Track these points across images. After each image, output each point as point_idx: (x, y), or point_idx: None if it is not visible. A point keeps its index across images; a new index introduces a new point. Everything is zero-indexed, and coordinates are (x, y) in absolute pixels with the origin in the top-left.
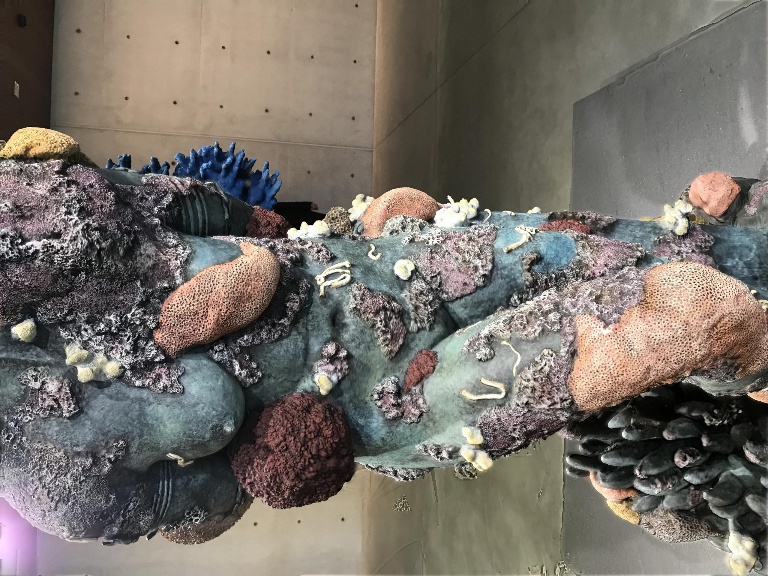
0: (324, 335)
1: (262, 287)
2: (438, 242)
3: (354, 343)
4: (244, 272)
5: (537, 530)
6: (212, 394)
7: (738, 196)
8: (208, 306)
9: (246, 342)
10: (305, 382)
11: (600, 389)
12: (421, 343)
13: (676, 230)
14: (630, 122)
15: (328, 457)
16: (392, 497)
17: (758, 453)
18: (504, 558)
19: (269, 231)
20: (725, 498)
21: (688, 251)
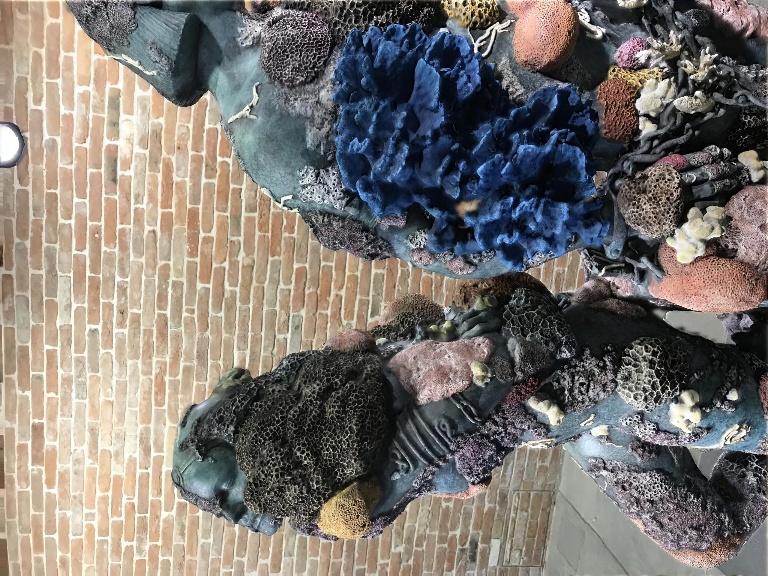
0: None
1: None
2: None
3: None
4: None
5: None
6: None
7: None
8: None
9: None
10: None
11: None
12: None
13: None
14: None
15: None
16: None
17: None
18: None
19: None
20: None
21: None
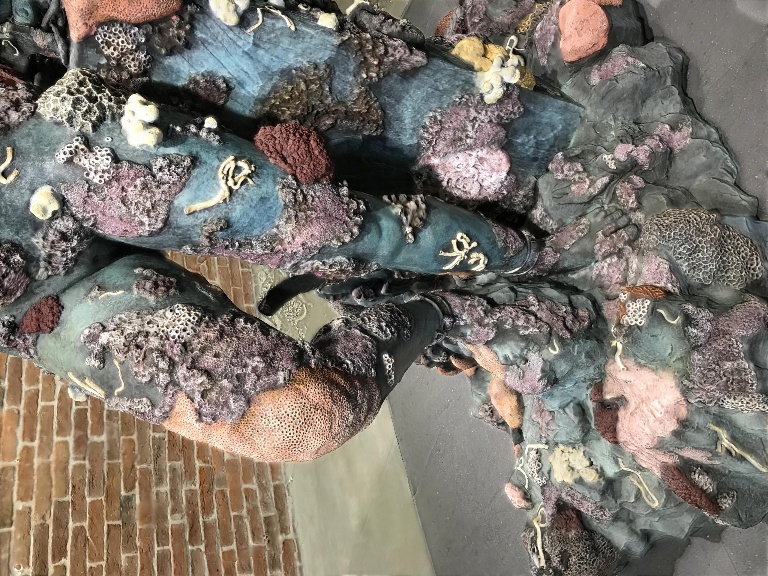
0: None
1: None
2: (100, 182)
3: None
4: None
5: None
6: None
7: (596, 52)
8: None
9: None
10: None
11: None
12: (50, 288)
13: (486, 96)
14: None
15: None
16: None
17: None
18: None
19: None
20: None
21: (485, 120)
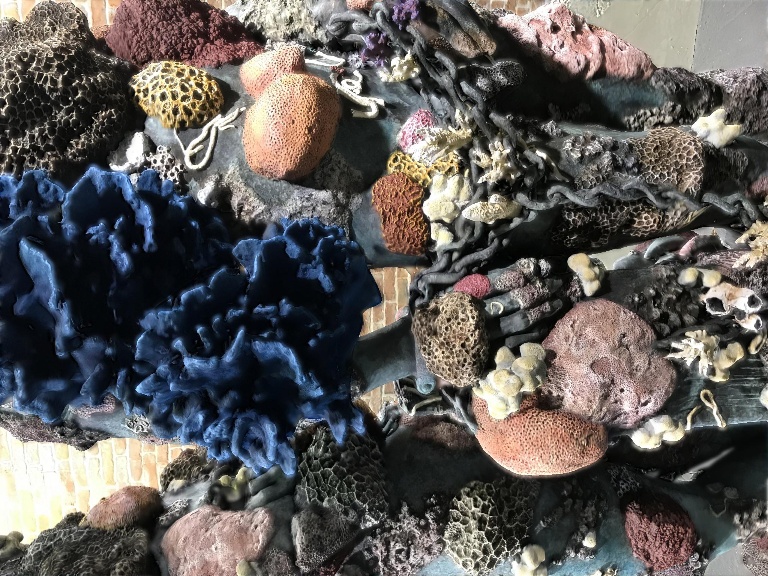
0: None
1: None
2: None
3: None
4: None
5: None
6: None
7: None
8: None
9: None
10: None
11: None
12: None
13: None
14: None
15: None
16: None
17: None
18: None
19: None
20: None
21: None
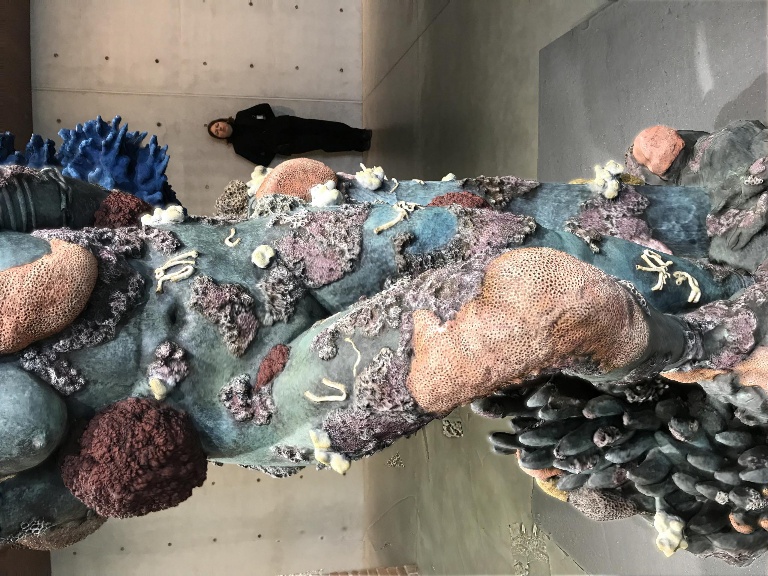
0: (159, 335)
1: (69, 289)
2: (302, 225)
3: (195, 342)
4: (44, 275)
5: (516, 489)
6: (16, 408)
7: (682, 152)
8: (2, 314)
9: (63, 348)
10: (140, 386)
11: (441, 391)
12: (277, 337)
13: (605, 193)
14: (593, 70)
15: (162, 466)
16: (386, 454)
17: (682, 431)
18: (487, 515)
19: (120, 218)
20: (648, 477)
21: (618, 215)
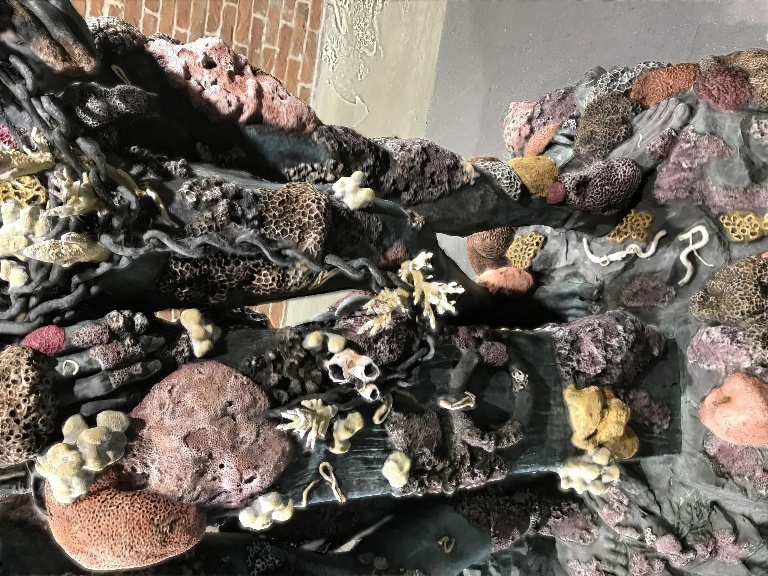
0: None
1: None
2: None
3: None
4: None
5: None
6: None
7: None
8: None
9: None
10: None
11: None
12: None
13: None
14: None
15: None
16: None
17: None
18: None
19: None
20: None
21: None
